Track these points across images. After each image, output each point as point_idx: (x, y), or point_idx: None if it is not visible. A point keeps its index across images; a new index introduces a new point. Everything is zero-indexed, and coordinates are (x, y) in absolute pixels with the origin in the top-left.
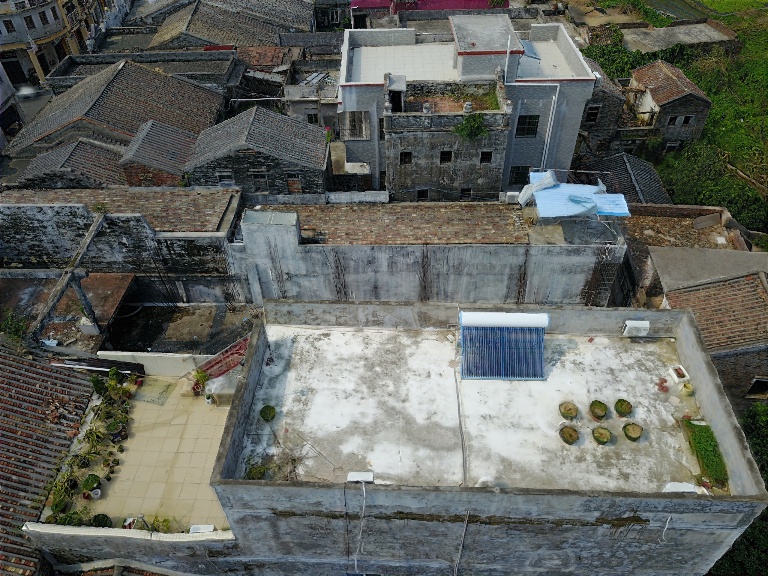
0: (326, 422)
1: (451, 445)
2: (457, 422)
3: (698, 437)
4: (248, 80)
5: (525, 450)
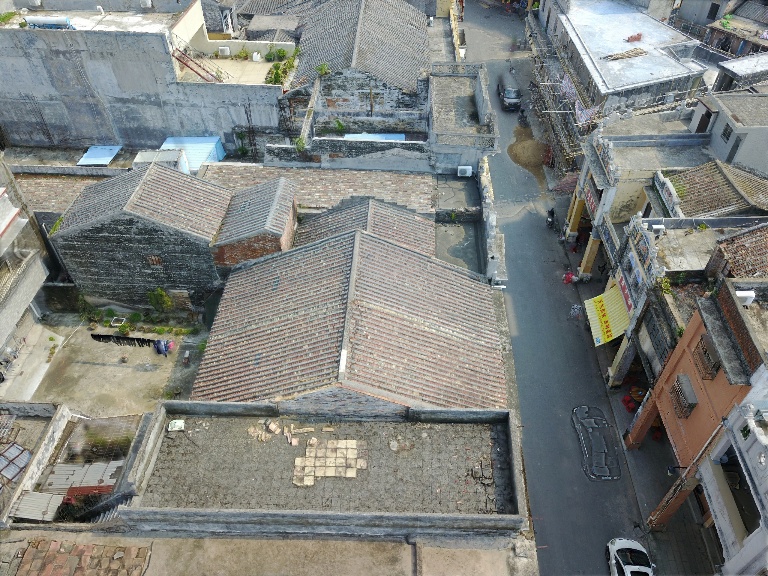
0: (154, 26)
1: (106, 21)
2: (98, 25)
3: (5, 18)
4: (123, 443)
5: (77, 20)
